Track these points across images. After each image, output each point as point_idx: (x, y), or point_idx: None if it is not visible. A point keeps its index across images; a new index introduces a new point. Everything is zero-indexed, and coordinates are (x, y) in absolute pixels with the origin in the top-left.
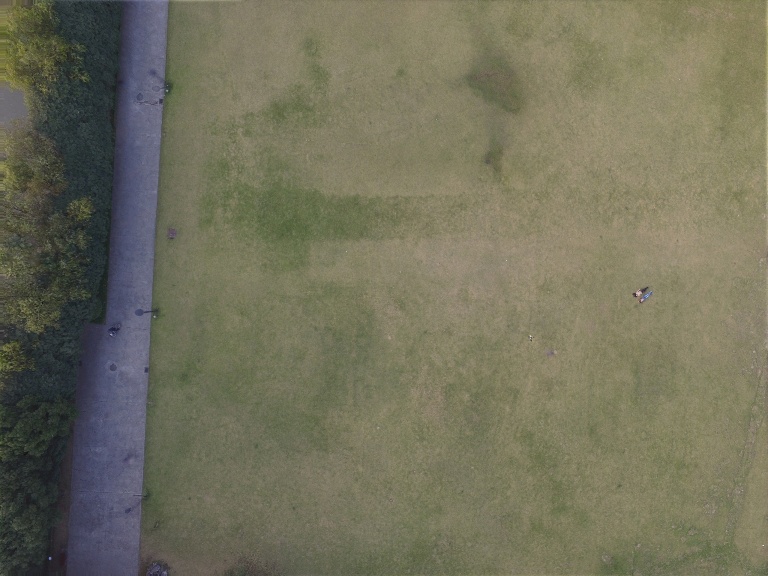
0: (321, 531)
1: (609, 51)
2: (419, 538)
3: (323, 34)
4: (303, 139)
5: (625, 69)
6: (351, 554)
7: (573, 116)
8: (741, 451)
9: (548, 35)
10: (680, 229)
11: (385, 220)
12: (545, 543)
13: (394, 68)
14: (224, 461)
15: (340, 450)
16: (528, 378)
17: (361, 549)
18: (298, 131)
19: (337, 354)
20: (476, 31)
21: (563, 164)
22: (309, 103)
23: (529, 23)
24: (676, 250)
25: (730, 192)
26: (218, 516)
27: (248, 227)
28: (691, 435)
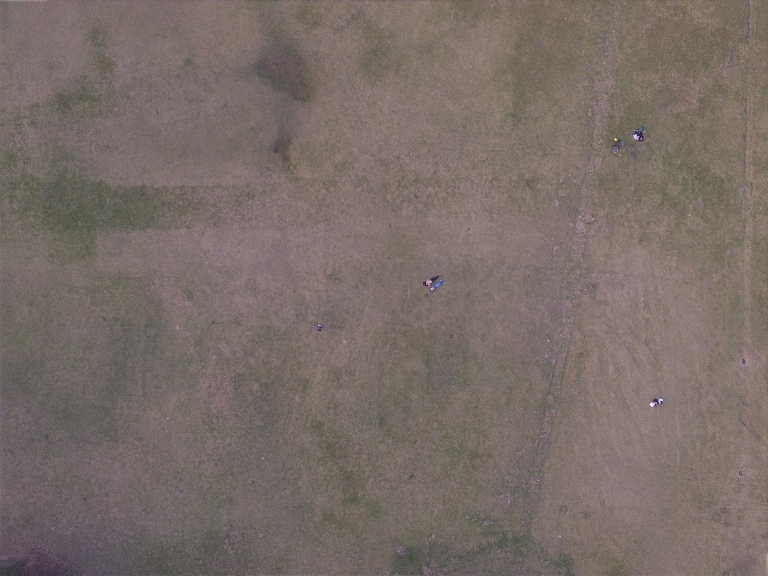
0: (112, 522)
1: (399, 38)
2: (210, 529)
3: (110, 24)
4: (89, 129)
5: (415, 56)
6: (142, 545)
7: (361, 104)
8: (536, 441)
9: (337, 23)
10: (471, 217)
11: (172, 210)
12: (337, 534)
13: (181, 57)
14: (15, 452)
15: (130, 441)
16: (317, 368)
17: (152, 540)
18: (84, 121)
19: (126, 345)
20: (265, 20)
21: (350, 152)
22: (95, 93)
23: (318, 11)
24: (467, 238)
25: (522, 179)
26: (9, 507)
27: (34, 218)
28: (484, 425)
